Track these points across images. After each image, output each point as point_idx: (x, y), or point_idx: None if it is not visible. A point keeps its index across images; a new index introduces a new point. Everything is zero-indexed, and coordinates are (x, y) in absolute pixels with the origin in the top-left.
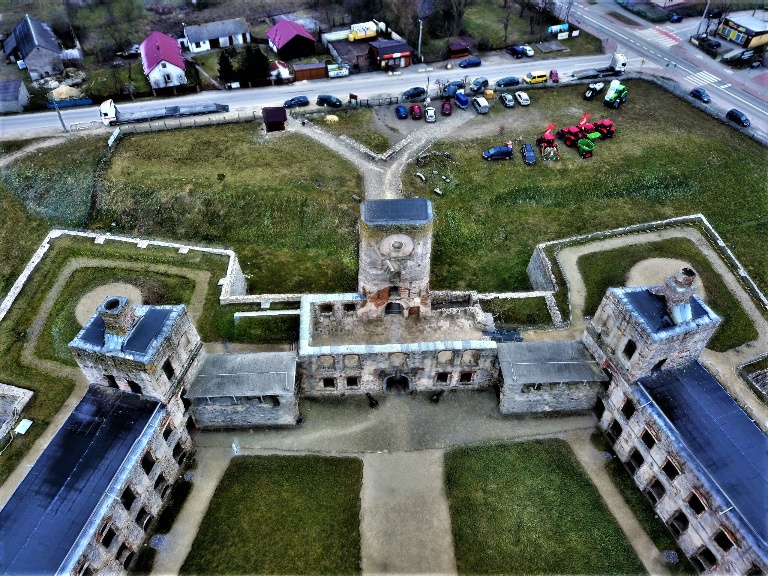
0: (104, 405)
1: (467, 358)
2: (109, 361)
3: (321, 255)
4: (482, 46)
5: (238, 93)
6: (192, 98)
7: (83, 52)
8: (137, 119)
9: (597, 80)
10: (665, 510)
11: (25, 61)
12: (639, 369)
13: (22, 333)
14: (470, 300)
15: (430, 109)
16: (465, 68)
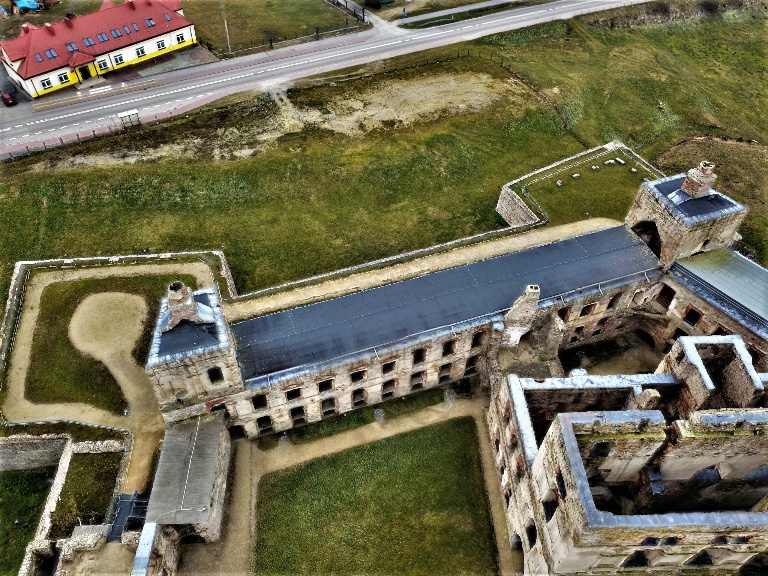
0: None
1: None
2: None
3: None
4: None
5: None
6: None
7: None
8: None
9: None
10: (345, 405)
11: None
12: (238, 374)
13: None
14: (41, 554)
15: None
16: None
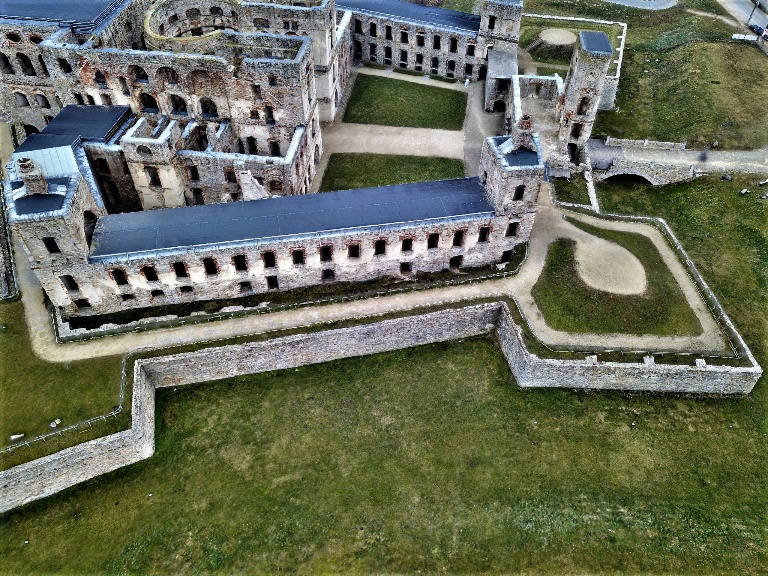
0: (478, 20)
1: None
2: None
3: None
4: None
5: None
6: None
7: None
8: None
9: None
10: None
11: None
12: None
13: (542, 25)
14: None
15: None
16: None
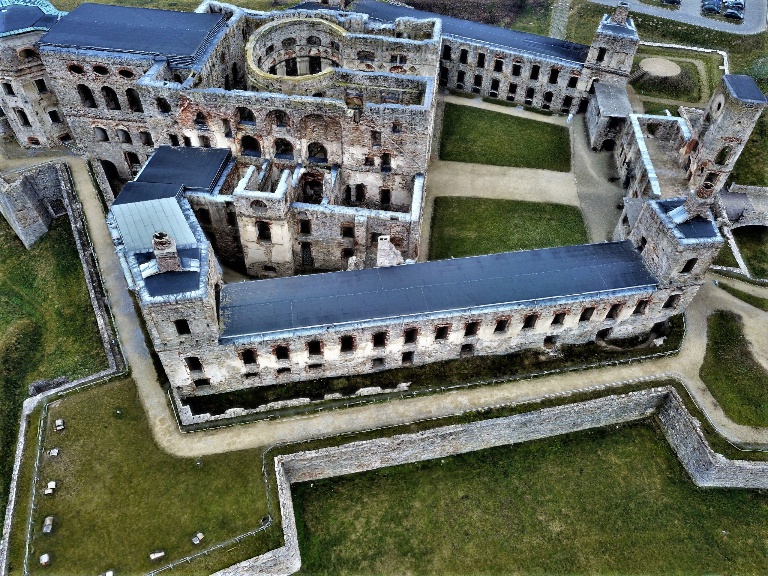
0: (581, 49)
1: None
2: None
3: (767, 186)
4: None
5: None
6: None
7: None
8: None
9: None
10: None
11: None
12: None
13: None
14: None
15: None
16: None
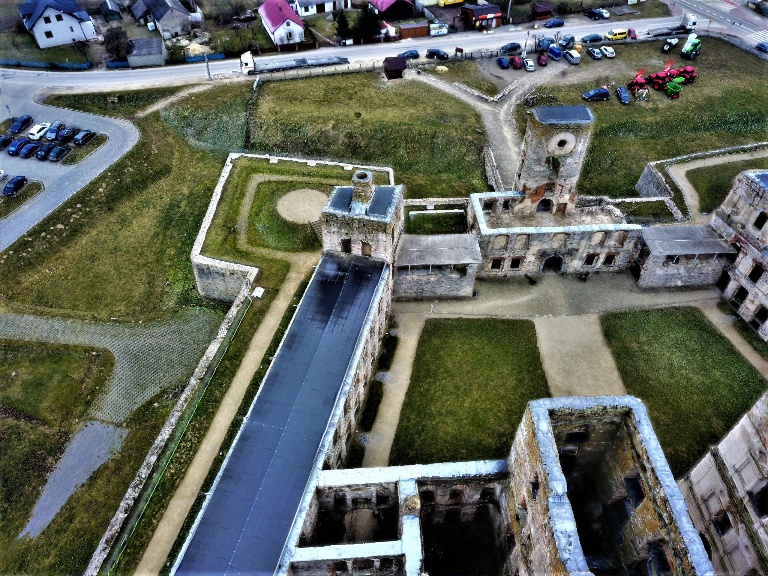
0: (342, 264)
1: (612, 242)
2: (355, 223)
3: (453, 179)
4: (562, 10)
5: (353, 49)
6: (313, 53)
7: (204, 16)
8: (271, 69)
9: (670, 37)
10: None
11: (160, 22)
12: None
13: (232, 228)
14: (601, 203)
15: (529, 60)
16: (550, 28)
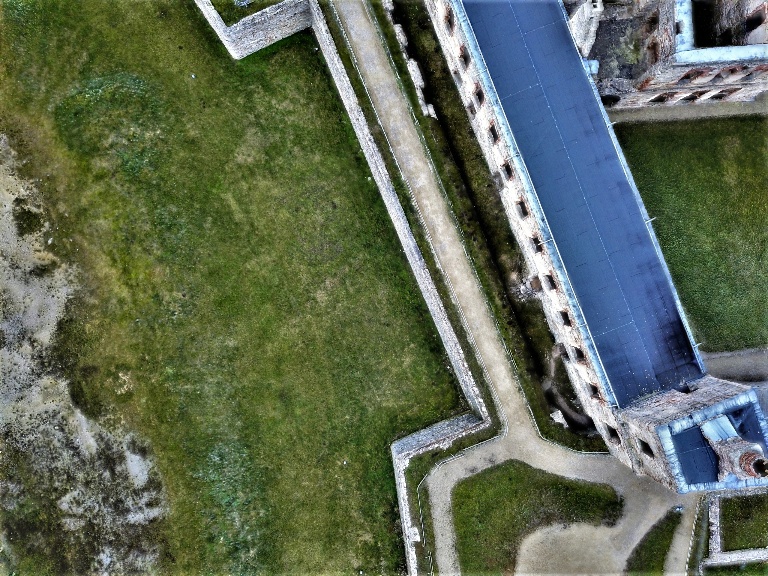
0: None
1: None
2: None
3: None
4: None
5: None
6: None
7: None
8: None
9: None
10: None
11: None
12: None
13: None
14: None
15: None
16: None
